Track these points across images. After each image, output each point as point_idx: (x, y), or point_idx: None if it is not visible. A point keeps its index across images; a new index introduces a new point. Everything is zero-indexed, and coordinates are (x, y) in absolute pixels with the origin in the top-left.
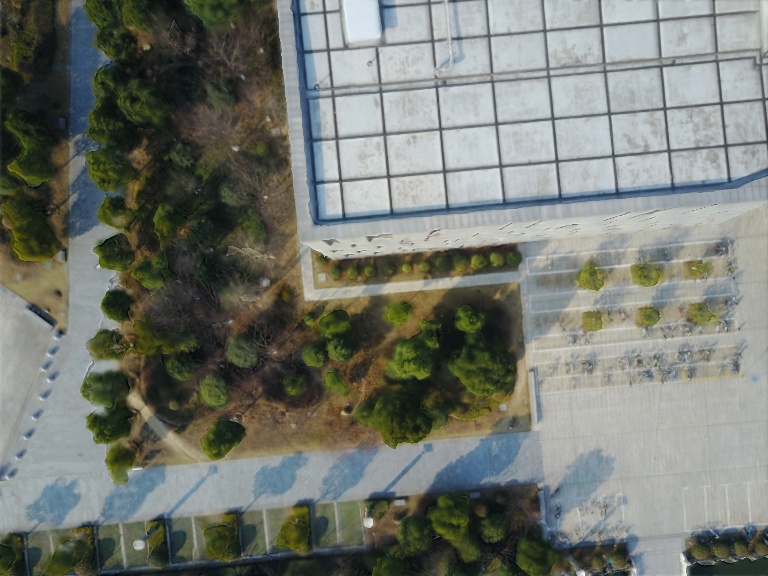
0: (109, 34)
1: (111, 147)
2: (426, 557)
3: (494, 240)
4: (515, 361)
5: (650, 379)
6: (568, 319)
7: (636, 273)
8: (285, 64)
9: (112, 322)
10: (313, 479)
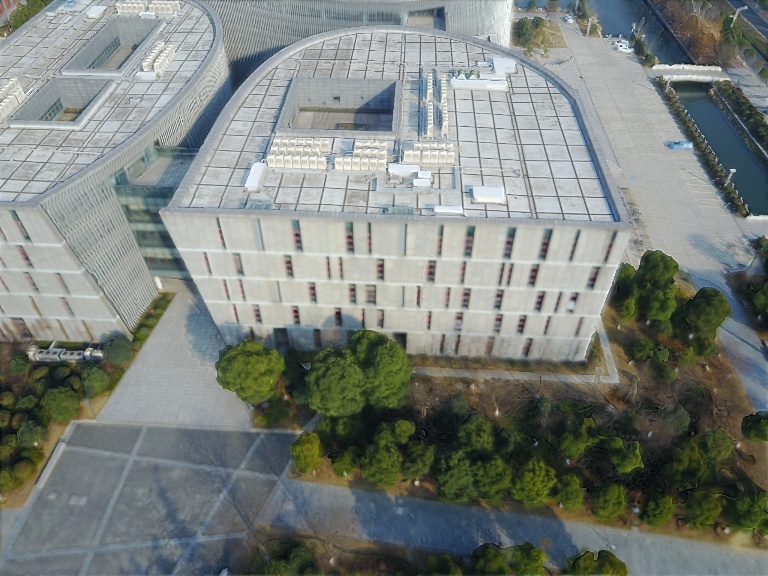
0: (412, 454)
1: (514, 466)
2: None
3: None
4: None
5: (639, 220)
6: None
7: None
8: (521, 223)
9: (675, 507)
10: None
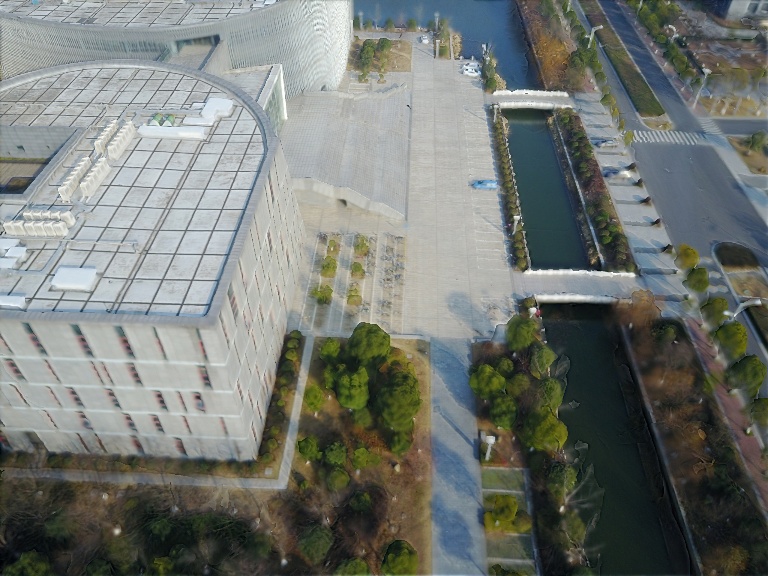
0: None
1: None
2: None
3: (274, 326)
4: None
5: (401, 276)
6: (350, 313)
7: (326, 271)
8: (81, 319)
9: None
10: (458, 506)
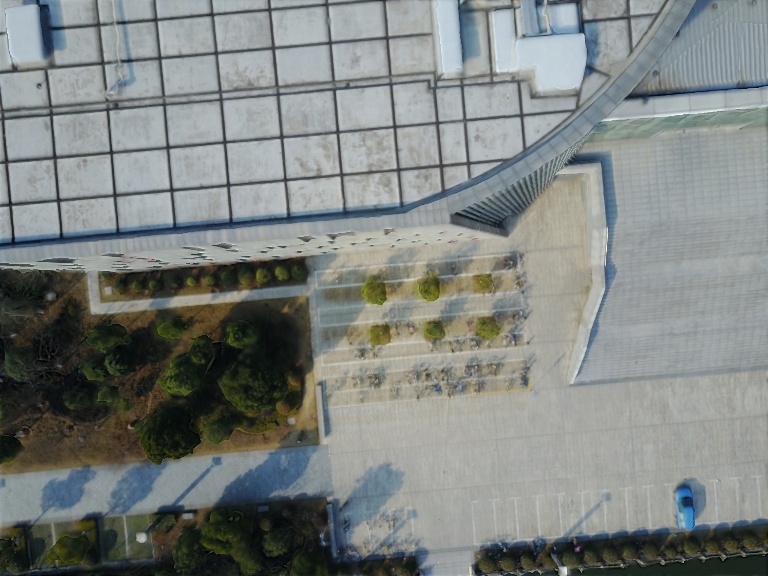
0: None
1: None
2: (210, 571)
3: (263, 255)
4: (302, 375)
5: (438, 393)
6: (357, 333)
7: (419, 287)
8: None
9: None
10: (102, 492)
